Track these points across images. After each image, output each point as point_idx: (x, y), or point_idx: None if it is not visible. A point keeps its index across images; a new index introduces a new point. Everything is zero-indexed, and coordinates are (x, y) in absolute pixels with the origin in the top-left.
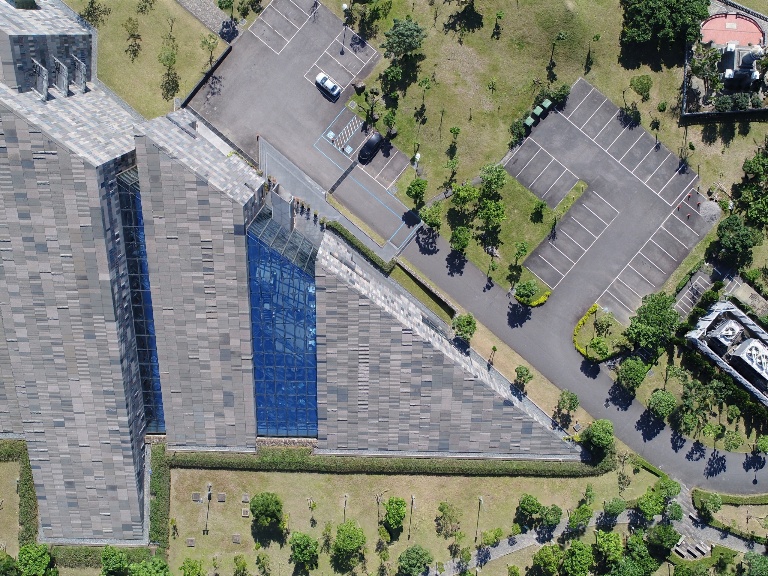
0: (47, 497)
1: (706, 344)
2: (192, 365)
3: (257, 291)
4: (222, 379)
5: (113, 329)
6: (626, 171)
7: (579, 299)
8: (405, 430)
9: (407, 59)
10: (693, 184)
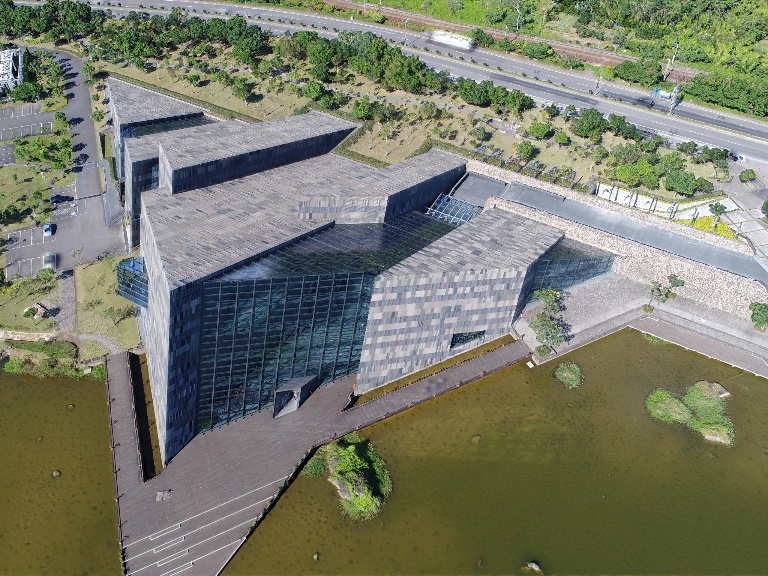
0: None
1: None
2: None
3: None
4: None
5: None
6: None
7: None
8: None
9: None
10: None
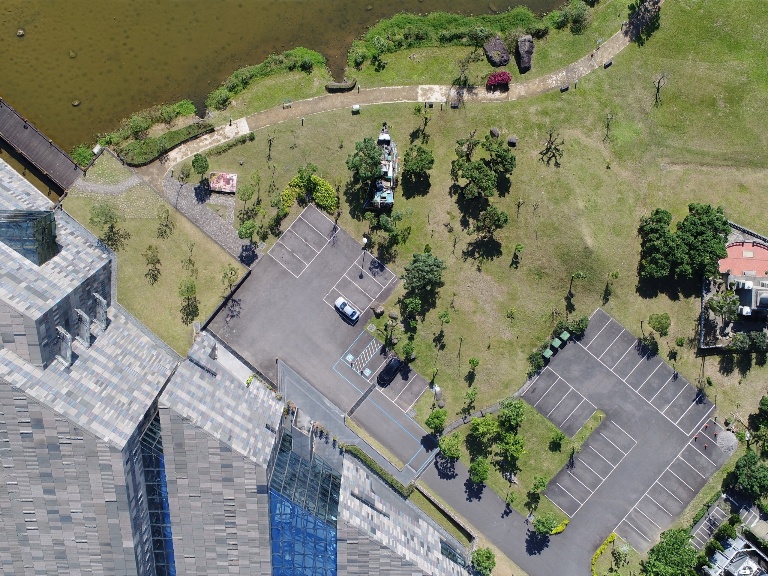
0: None
1: None
2: None
3: None
4: None
5: None
6: (644, 401)
7: (597, 528)
8: None
9: None
10: (710, 414)
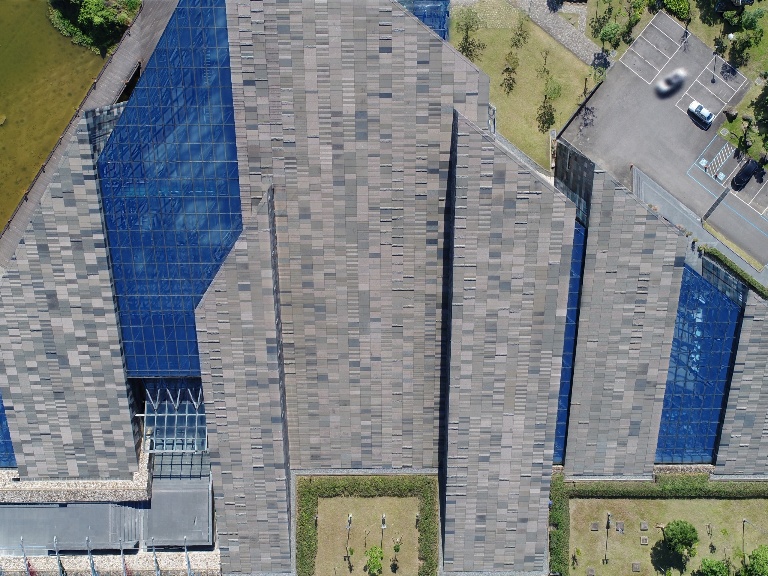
0: (455, 531)
1: None
2: (605, 396)
3: None
4: (632, 409)
5: (559, 364)
6: None
7: None
8: None
9: None
10: None
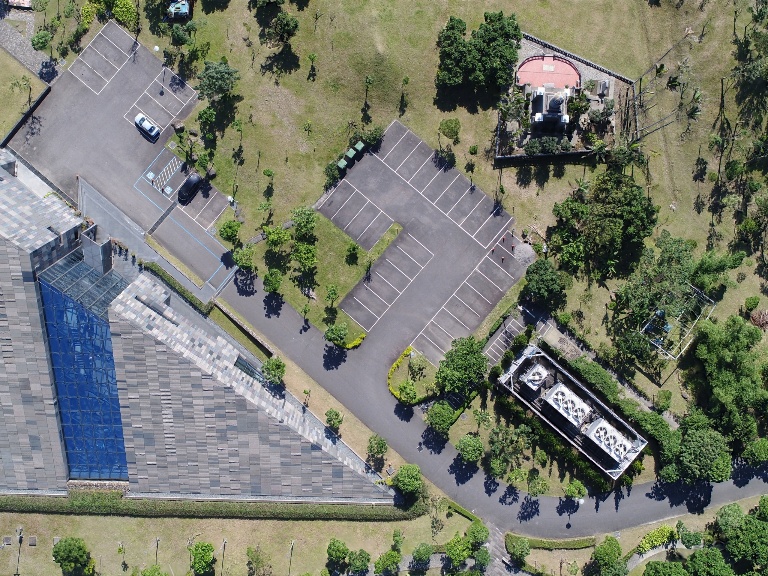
0: None
1: (512, 389)
2: None
3: None
4: (27, 423)
5: None
6: (441, 213)
7: (394, 342)
8: (215, 474)
9: (225, 100)
10: (508, 227)
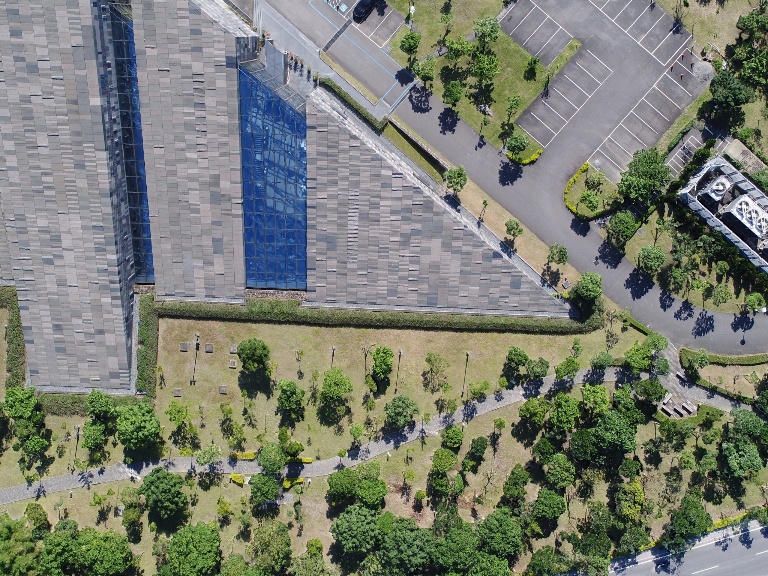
0: (35, 341)
1: (696, 198)
2: (182, 208)
3: (249, 139)
4: (212, 224)
5: (103, 159)
6: (620, 30)
7: (571, 157)
8: (394, 283)
9: None
10: (687, 44)
